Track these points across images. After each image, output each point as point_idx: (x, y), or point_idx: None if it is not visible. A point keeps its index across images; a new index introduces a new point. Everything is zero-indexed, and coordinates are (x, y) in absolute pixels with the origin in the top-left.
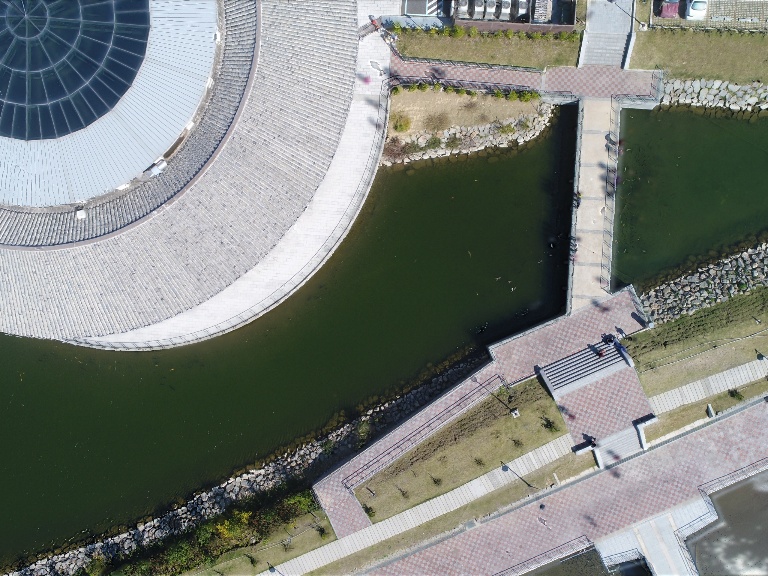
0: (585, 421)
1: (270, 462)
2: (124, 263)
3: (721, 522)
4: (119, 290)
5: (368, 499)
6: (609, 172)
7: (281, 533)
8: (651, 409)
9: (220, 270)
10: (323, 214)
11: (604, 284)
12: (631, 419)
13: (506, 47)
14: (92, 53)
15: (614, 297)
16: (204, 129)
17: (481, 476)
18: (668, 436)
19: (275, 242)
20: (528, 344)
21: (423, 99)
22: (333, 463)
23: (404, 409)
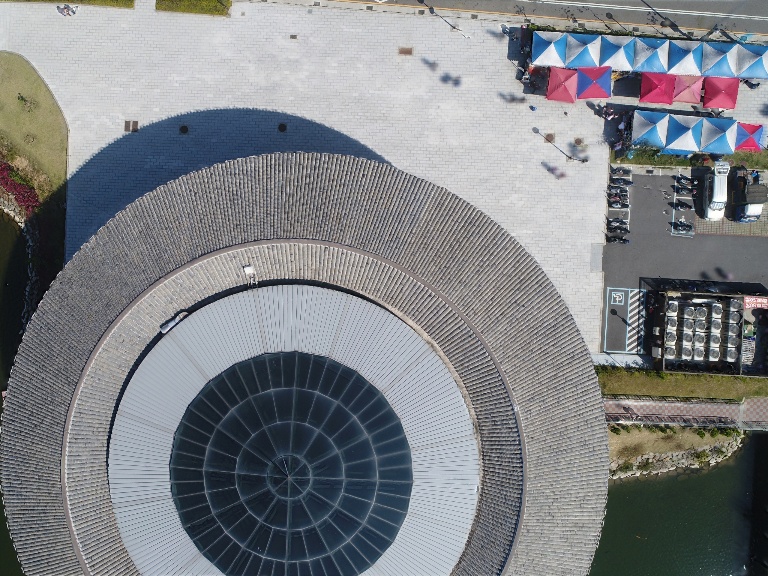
0: None
1: None
2: None
3: None
4: None
5: None
6: None
7: None
8: None
9: None
10: None
11: None
12: None
13: (707, 383)
14: (355, 511)
15: None
16: (463, 575)
17: None
18: None
19: None
20: None
21: (621, 434)
22: None
23: None
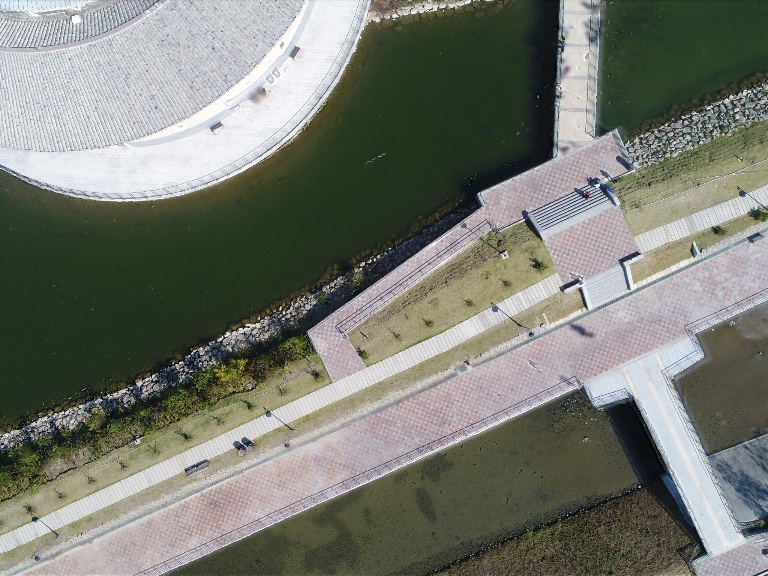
0: (573, 261)
1: (265, 316)
2: (118, 66)
3: (708, 371)
4: (114, 96)
5: (362, 343)
6: (592, 19)
7: (277, 378)
8: (637, 247)
9: (212, 78)
10: (314, 62)
11: (589, 129)
12: (617, 258)
13: None
14: None
15: (599, 141)
16: None
17: (472, 317)
18: (654, 277)
19: (265, 52)
20: (516, 189)
21: None
22: (327, 313)
23: (396, 259)
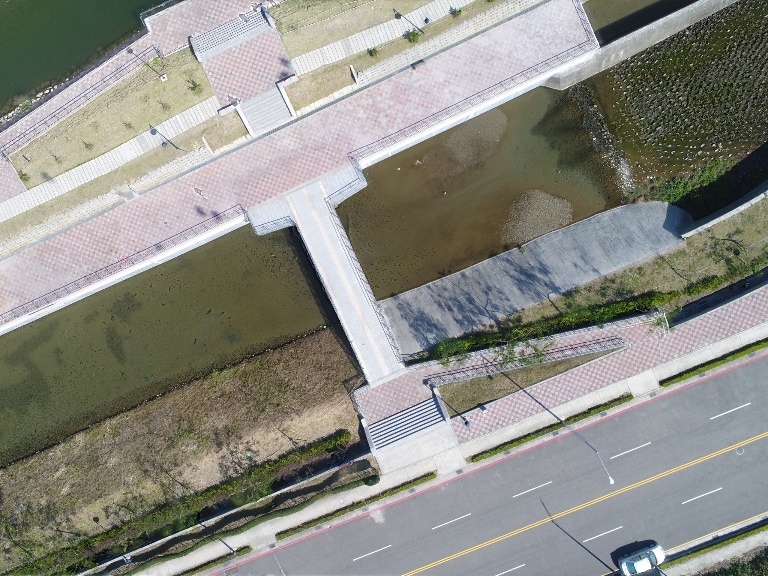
0: (230, 83)
1: None
2: None
3: (394, 211)
4: None
5: (23, 166)
6: None
7: None
8: (293, 70)
9: None
10: None
11: None
12: (274, 80)
13: None
14: None
15: None
16: None
17: (130, 140)
18: (317, 103)
19: None
20: (182, 15)
21: None
22: None
23: None
